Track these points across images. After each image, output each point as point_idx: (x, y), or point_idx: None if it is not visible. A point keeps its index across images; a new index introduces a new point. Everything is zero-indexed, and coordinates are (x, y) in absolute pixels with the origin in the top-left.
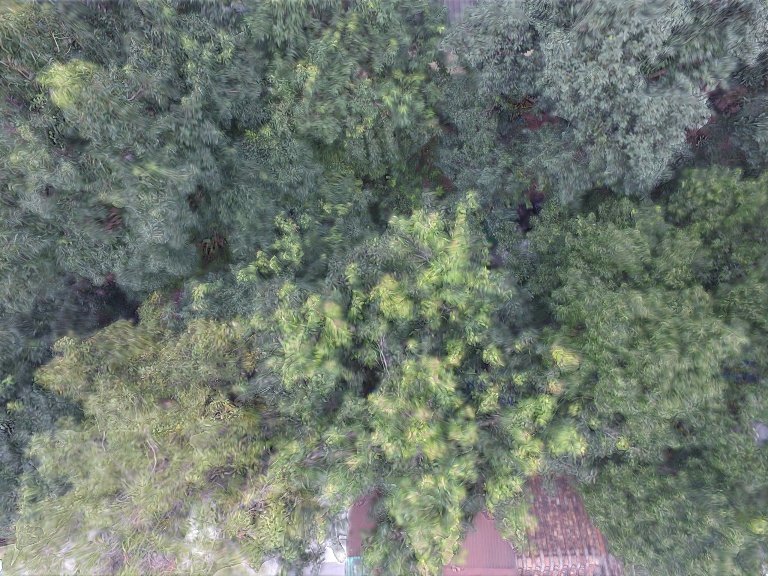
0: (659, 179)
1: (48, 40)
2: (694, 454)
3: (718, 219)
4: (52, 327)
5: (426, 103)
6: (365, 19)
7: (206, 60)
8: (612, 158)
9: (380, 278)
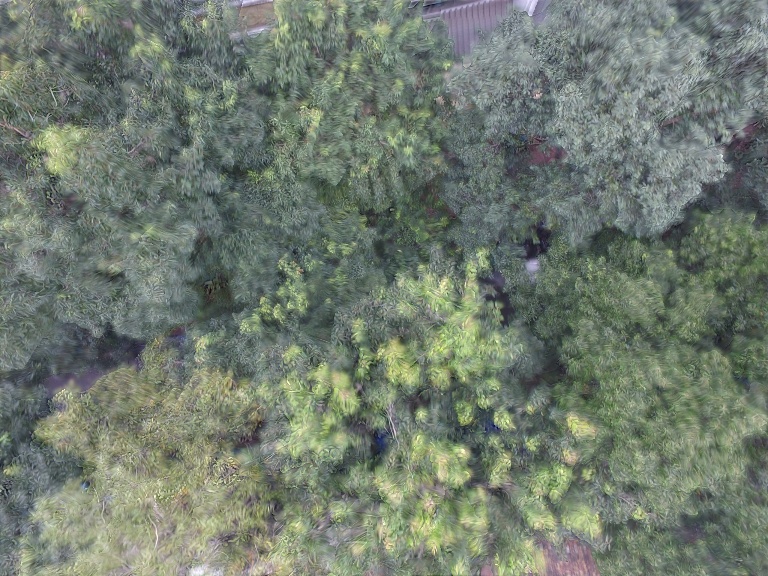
0: None
1: (45, 95)
2: (712, 519)
3: (733, 268)
4: (50, 362)
5: (431, 139)
6: (370, 59)
7: (208, 109)
8: (624, 206)
9: (387, 335)
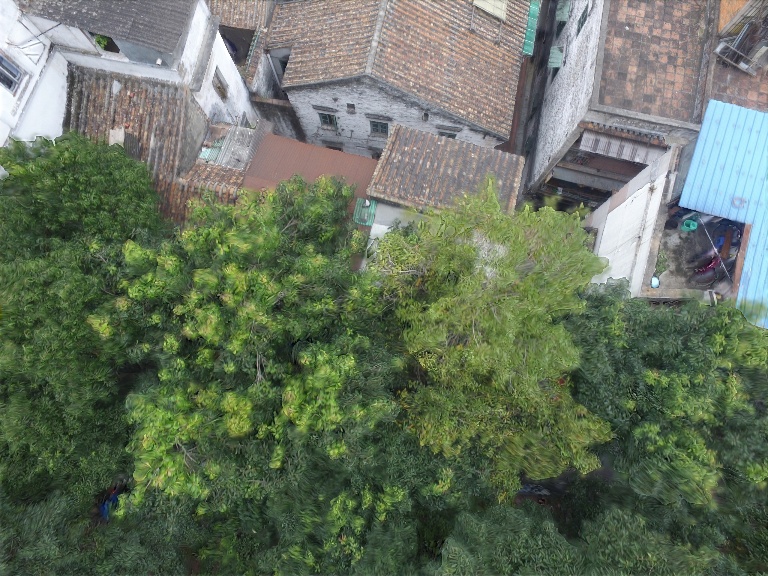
0: None
1: None
2: (47, 231)
3: None
4: None
5: None
6: None
7: None
8: None
9: (248, 450)
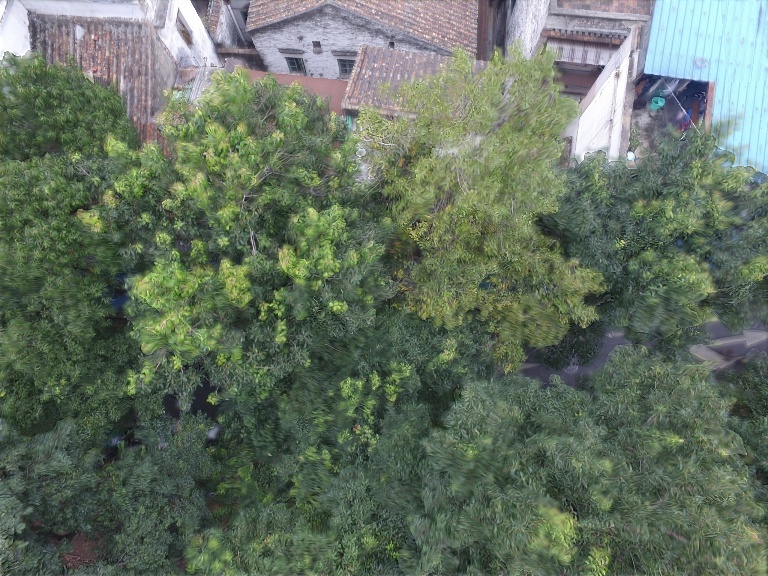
0: None
1: None
2: (26, 155)
3: None
4: None
5: None
6: None
7: None
8: None
9: (253, 332)
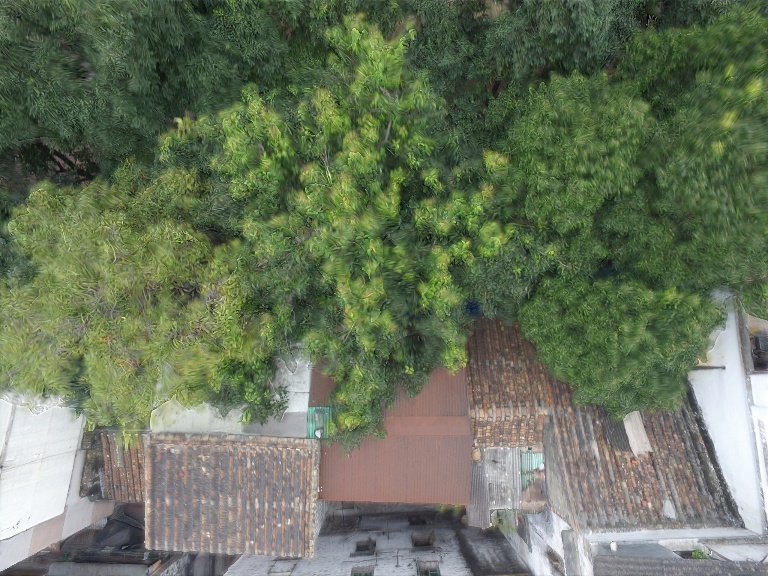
0: (607, 52)
1: None
2: (622, 273)
3: (656, 73)
4: None
5: None
6: None
7: None
8: (556, 16)
9: None
